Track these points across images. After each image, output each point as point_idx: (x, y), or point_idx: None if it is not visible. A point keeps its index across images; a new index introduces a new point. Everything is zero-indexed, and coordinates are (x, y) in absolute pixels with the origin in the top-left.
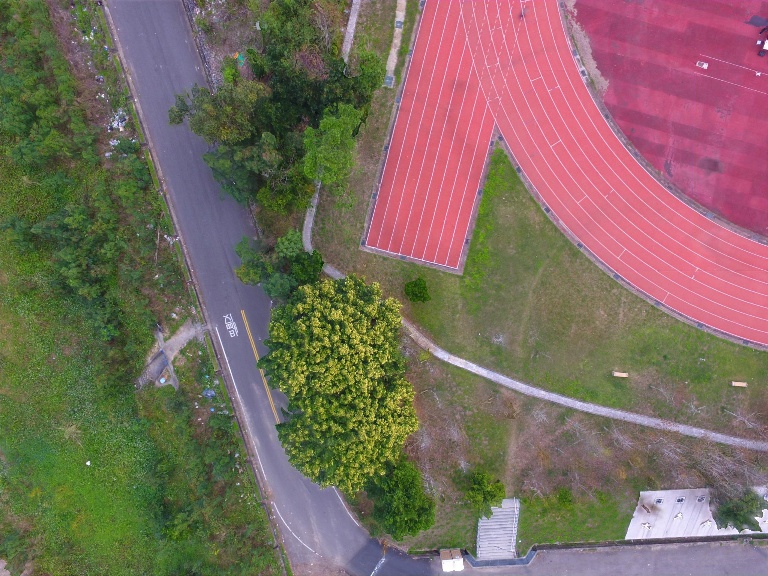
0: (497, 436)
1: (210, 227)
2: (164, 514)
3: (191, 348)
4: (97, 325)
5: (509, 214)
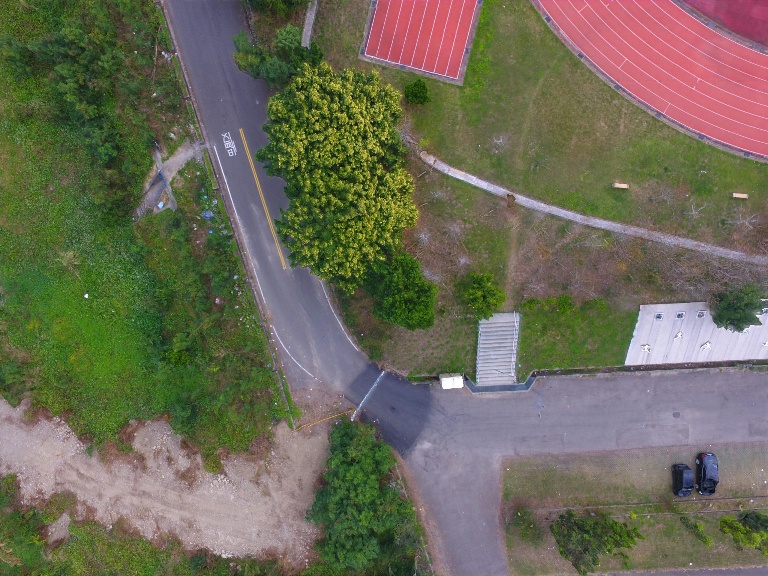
0: (497, 249)
1: (208, 43)
2: (163, 344)
3: (189, 169)
4: (94, 142)
5: (509, 23)
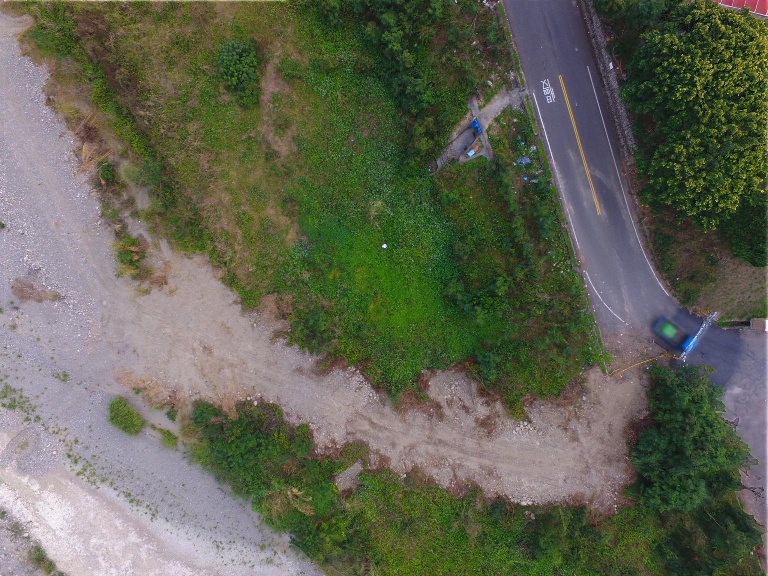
0: None
1: None
2: (466, 292)
3: (505, 116)
4: (418, 89)
5: None
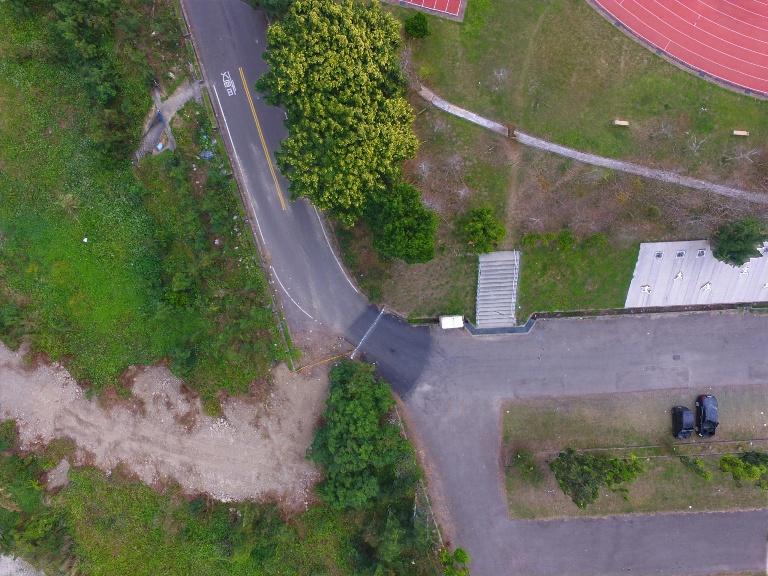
0: (497, 187)
1: None
2: (162, 287)
3: (189, 109)
4: (93, 80)
5: None
